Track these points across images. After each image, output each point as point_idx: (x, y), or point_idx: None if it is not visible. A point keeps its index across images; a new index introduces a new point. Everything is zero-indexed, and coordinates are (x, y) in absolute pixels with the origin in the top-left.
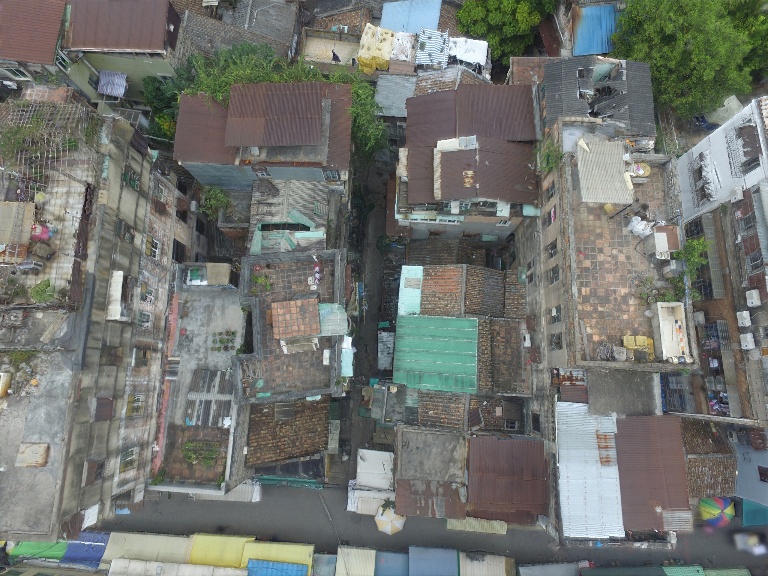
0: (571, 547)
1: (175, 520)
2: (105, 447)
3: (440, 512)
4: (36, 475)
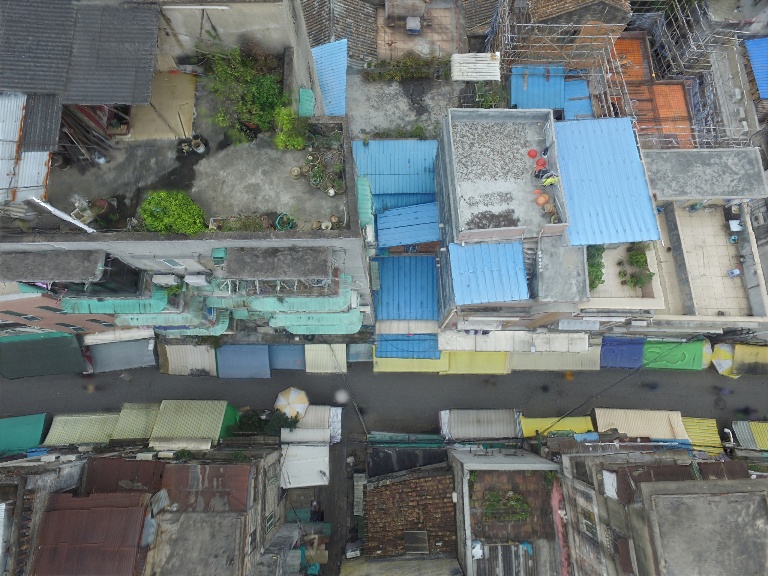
0: (108, 377)
1: (535, 376)
2: (620, 572)
3: (195, 472)
4: (700, 575)
